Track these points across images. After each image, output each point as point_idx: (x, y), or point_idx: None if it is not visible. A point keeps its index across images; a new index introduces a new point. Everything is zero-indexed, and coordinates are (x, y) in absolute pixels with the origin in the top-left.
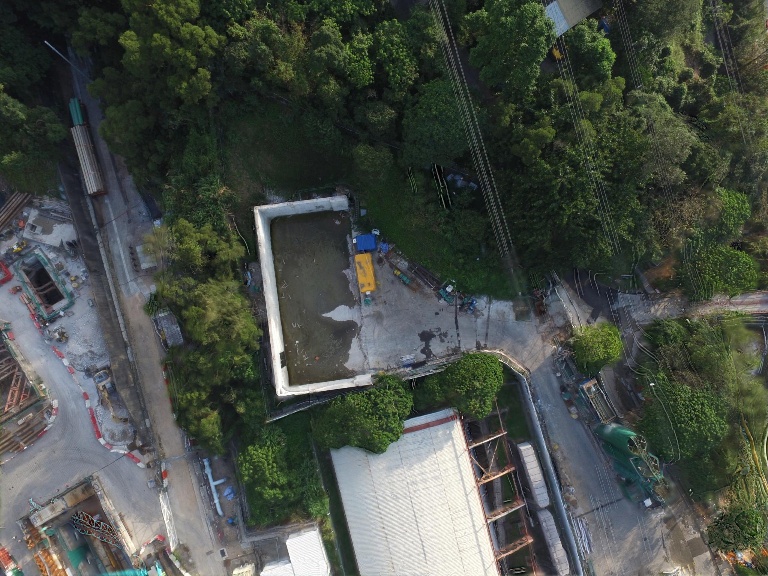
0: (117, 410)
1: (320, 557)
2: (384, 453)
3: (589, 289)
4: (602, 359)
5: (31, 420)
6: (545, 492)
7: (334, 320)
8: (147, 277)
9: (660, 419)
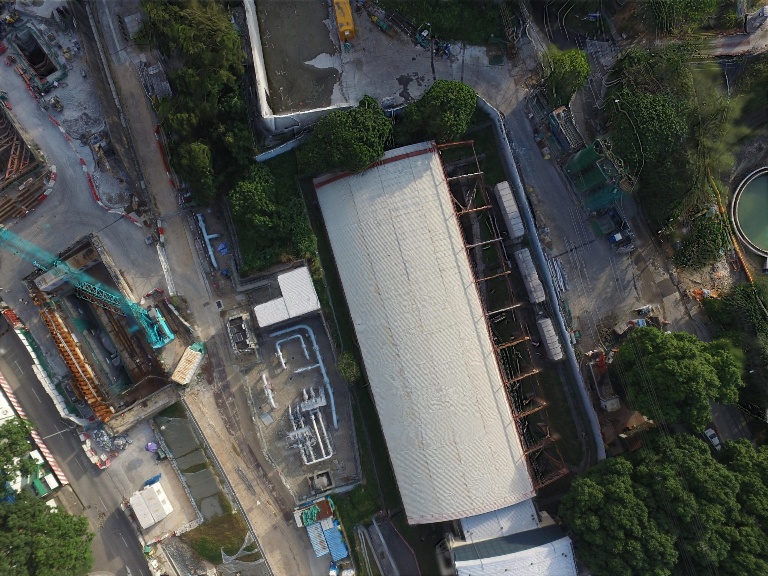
0: (113, 165)
1: (310, 290)
2: (367, 184)
3: (558, 33)
4: (569, 74)
5: (31, 186)
6: (520, 222)
7: (316, 67)
8: (136, 46)
9: (624, 127)
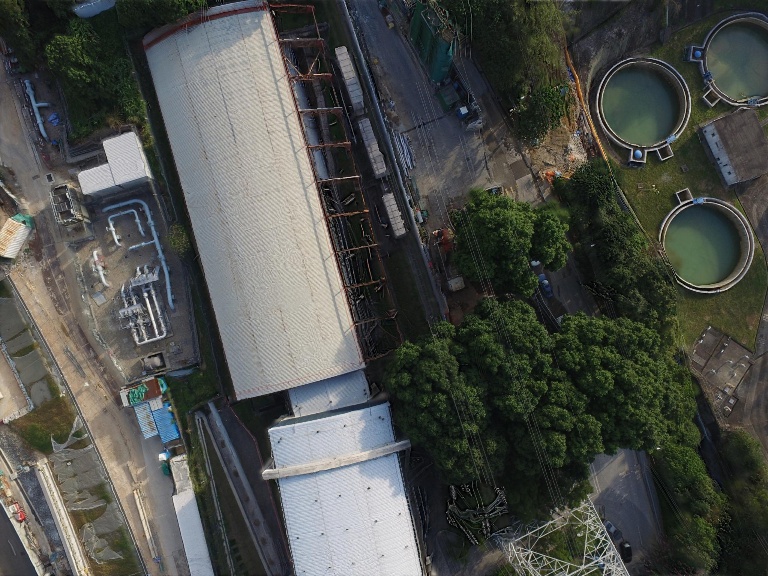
0: None
1: (137, 156)
2: (193, 41)
3: None
4: None
5: None
6: (358, 88)
7: None
8: None
9: None
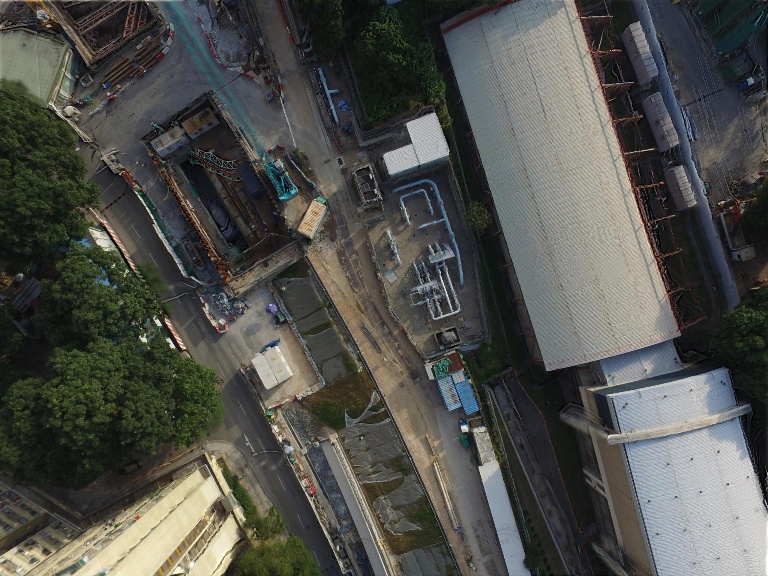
0: (235, 17)
1: (440, 136)
2: (500, 22)
3: None
4: None
5: (149, 45)
6: (654, 63)
7: None
8: None
9: None
